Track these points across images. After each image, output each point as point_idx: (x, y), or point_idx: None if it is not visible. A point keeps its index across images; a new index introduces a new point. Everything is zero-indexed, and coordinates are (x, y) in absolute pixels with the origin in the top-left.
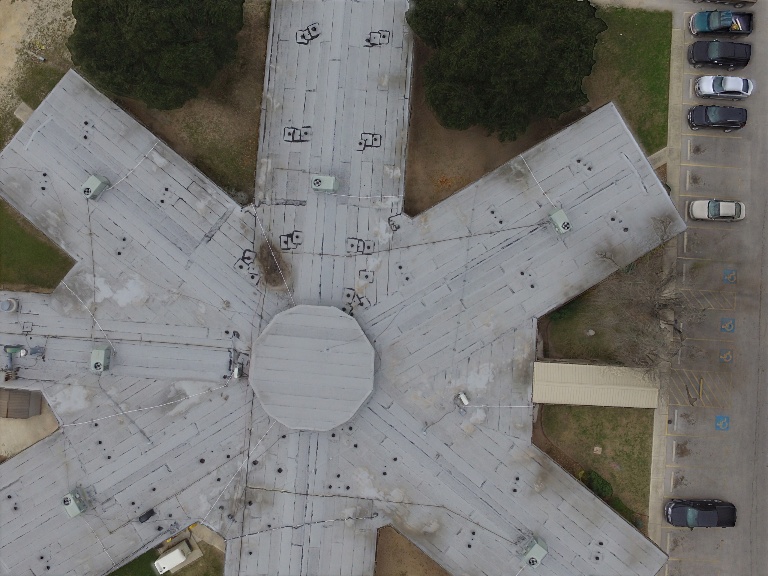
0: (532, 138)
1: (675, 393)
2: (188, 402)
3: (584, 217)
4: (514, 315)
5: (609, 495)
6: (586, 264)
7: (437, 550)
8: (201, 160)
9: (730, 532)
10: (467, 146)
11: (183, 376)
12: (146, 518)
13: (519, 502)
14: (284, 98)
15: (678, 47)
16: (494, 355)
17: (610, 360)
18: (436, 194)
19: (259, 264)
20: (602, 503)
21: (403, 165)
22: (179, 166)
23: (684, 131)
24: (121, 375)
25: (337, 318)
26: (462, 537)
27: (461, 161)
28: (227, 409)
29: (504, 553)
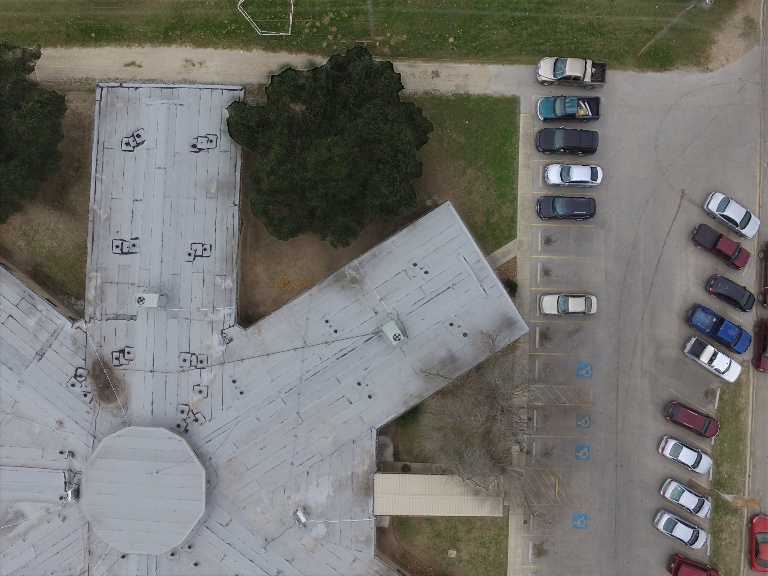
0: (376, 235)
1: (530, 493)
2: (26, 524)
3: (421, 323)
4: (352, 426)
5: None
6: None
7: None
8: (40, 269)
9: None
10: (310, 246)
11: (20, 498)
12: None
13: None
14: (111, 209)
15: (527, 133)
16: (333, 468)
17: None
18: (279, 297)
19: (92, 382)
20: None
21: (234, 275)
22: (8, 283)
23: (534, 221)
24: None
25: (166, 440)
26: None
27: (304, 262)
28: (64, 531)
29: None
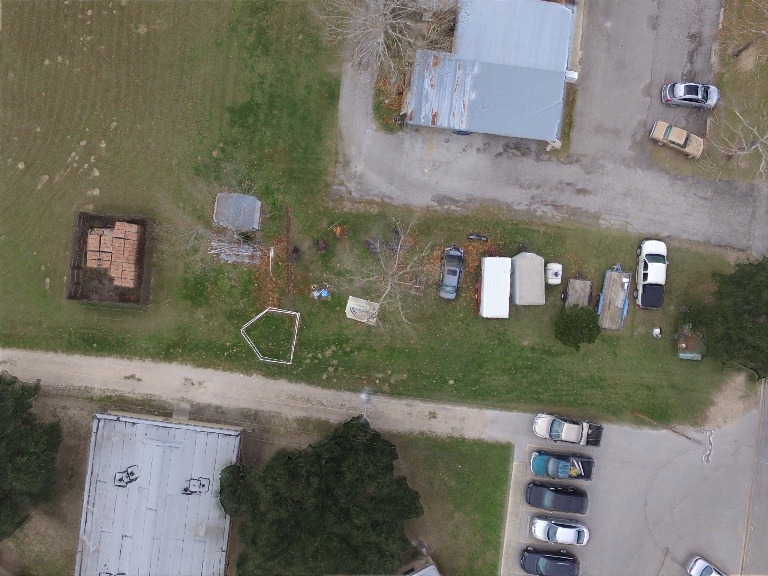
0: None
1: None
2: None
3: None
4: None
5: None
6: None
7: None
8: (27, 571)
9: None
10: None
11: None
12: None
13: None
14: (100, 542)
15: (519, 482)
16: None
17: None
18: None
19: None
20: None
21: None
22: None
23: (518, 570)
24: None
25: None
26: None
27: None
28: None
29: None
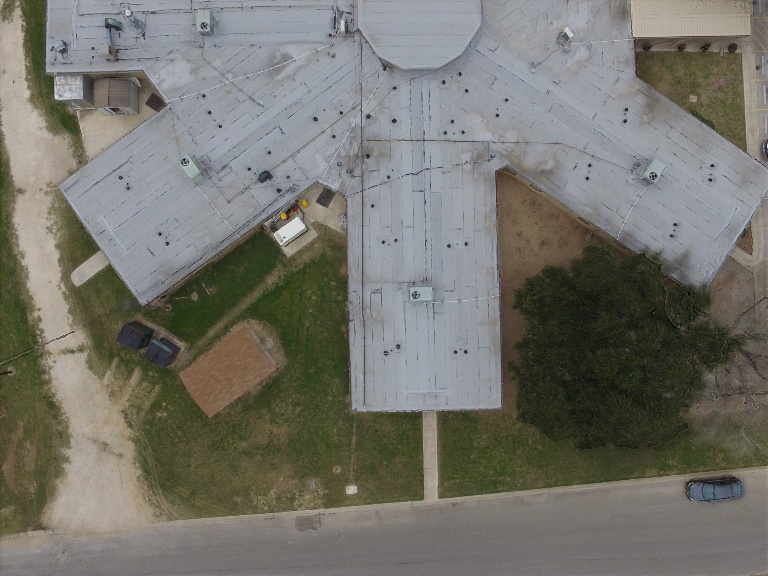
0: None
1: (760, 40)
2: (295, 65)
3: None
4: None
5: None
6: None
7: (556, 186)
8: None
9: None
10: None
11: (288, 40)
12: (266, 174)
13: (630, 132)
14: None
15: None
16: None
17: None
18: None
19: None
20: (709, 128)
21: None
22: None
23: None
24: (225, 45)
25: None
26: (579, 171)
27: None
28: (336, 65)
29: (621, 183)
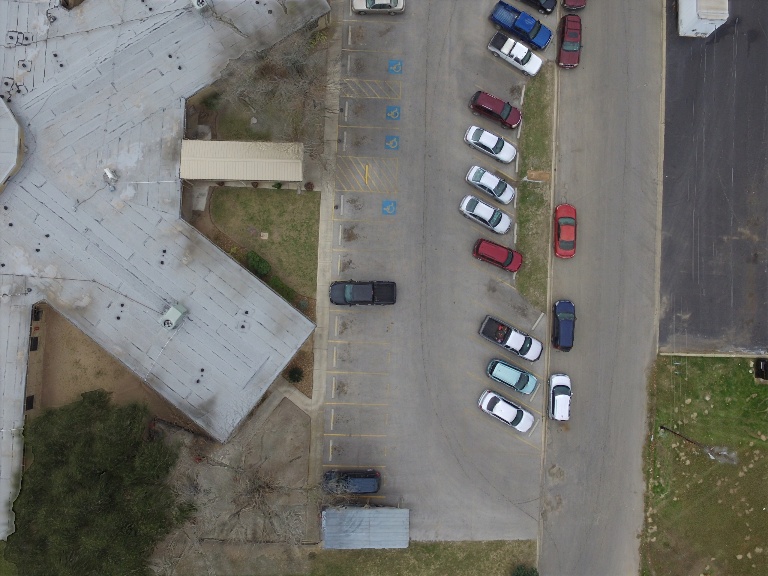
0: None
1: (341, 179)
2: None
3: (229, 1)
4: (163, 96)
5: (264, 271)
6: (232, 46)
7: (88, 323)
8: None
9: (400, 315)
10: None
11: None
12: None
13: (167, 274)
14: None
15: None
16: (144, 134)
17: (262, 139)
18: None
19: None
20: (248, 273)
21: None
22: None
23: None
24: None
25: None
26: (112, 310)
27: None
28: None
29: (153, 325)
